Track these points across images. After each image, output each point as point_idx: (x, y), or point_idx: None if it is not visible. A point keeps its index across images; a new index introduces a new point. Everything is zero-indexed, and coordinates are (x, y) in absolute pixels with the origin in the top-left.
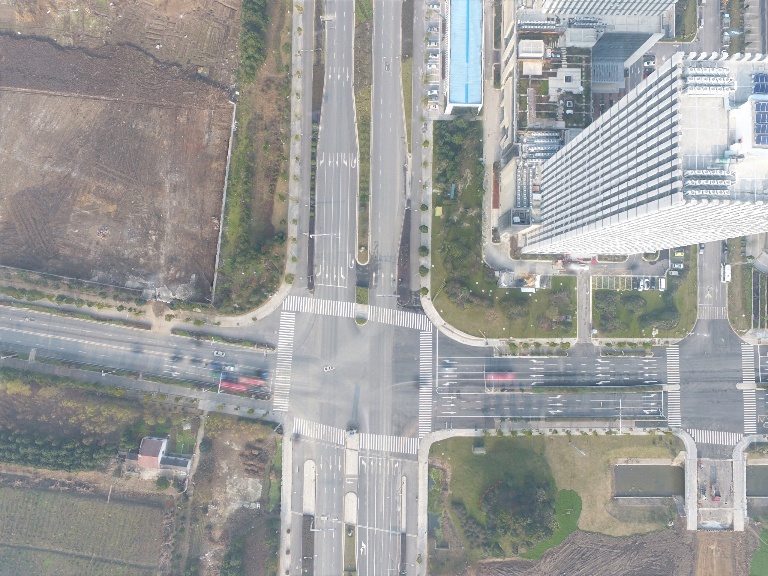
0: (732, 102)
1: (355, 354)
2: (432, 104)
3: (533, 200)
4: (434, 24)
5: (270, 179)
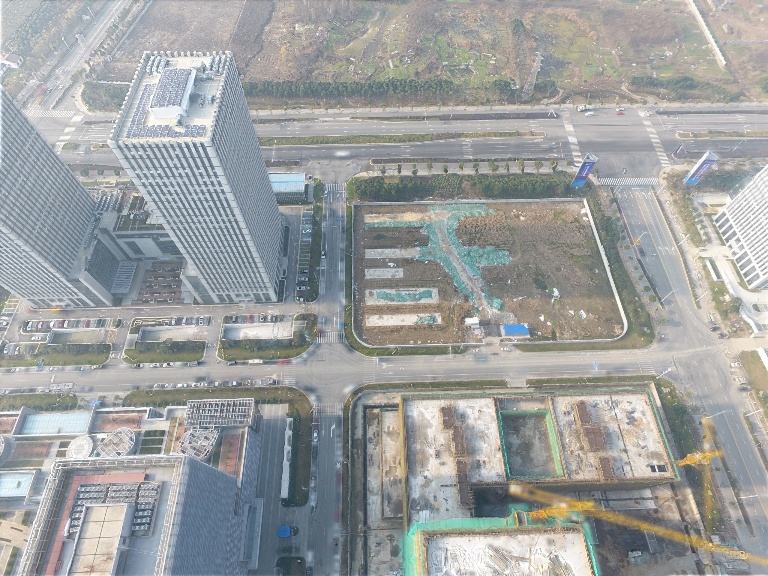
0: None
1: None
2: None
3: None
4: None
5: None
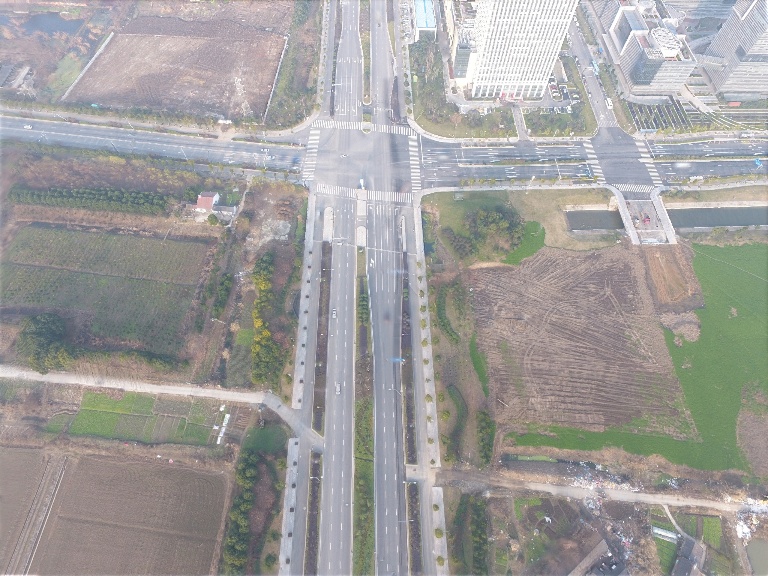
0: None
1: (363, 148)
2: None
3: (471, 45)
4: None
5: (307, 67)
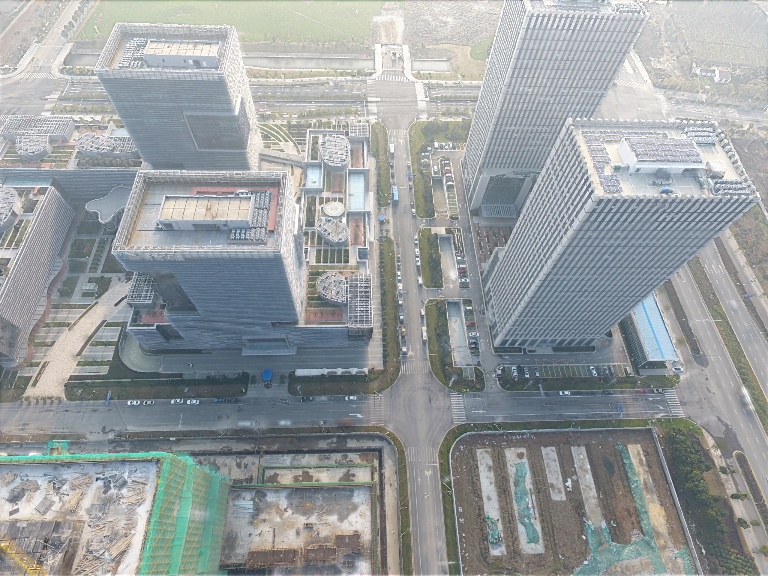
0: (609, 5)
1: (626, 115)
2: None
3: None
4: None
5: None
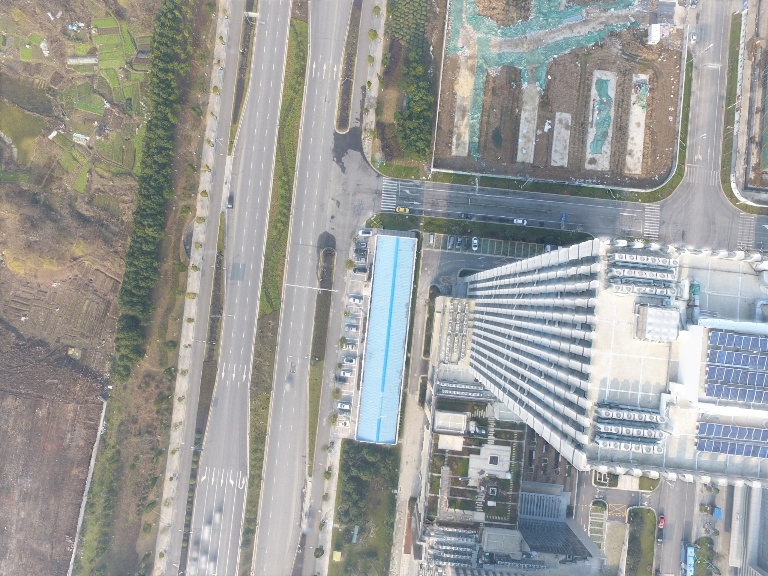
0: None
1: None
2: (342, 418)
3: None
4: (354, 320)
5: (139, 497)
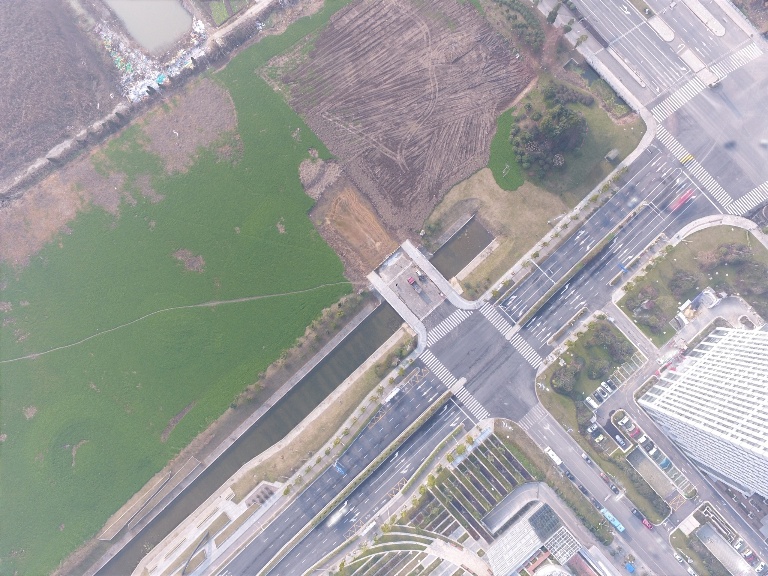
0: None
1: (765, 139)
2: None
3: None
4: None
5: None
